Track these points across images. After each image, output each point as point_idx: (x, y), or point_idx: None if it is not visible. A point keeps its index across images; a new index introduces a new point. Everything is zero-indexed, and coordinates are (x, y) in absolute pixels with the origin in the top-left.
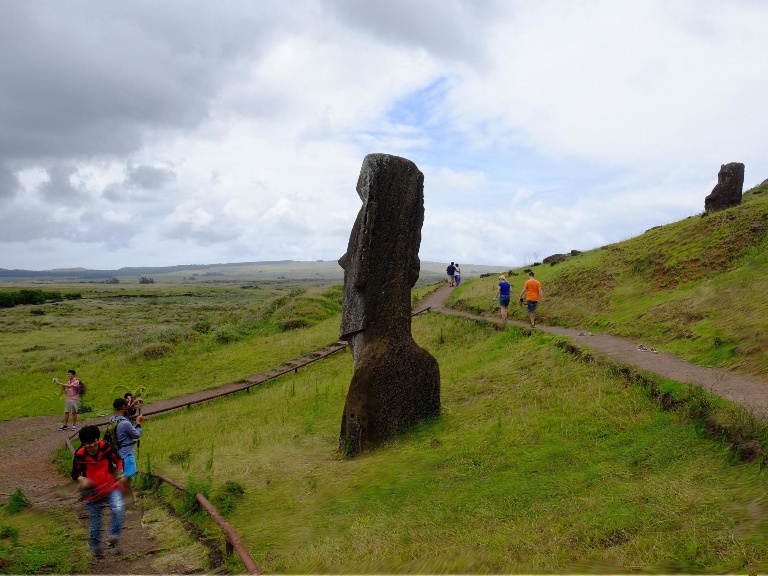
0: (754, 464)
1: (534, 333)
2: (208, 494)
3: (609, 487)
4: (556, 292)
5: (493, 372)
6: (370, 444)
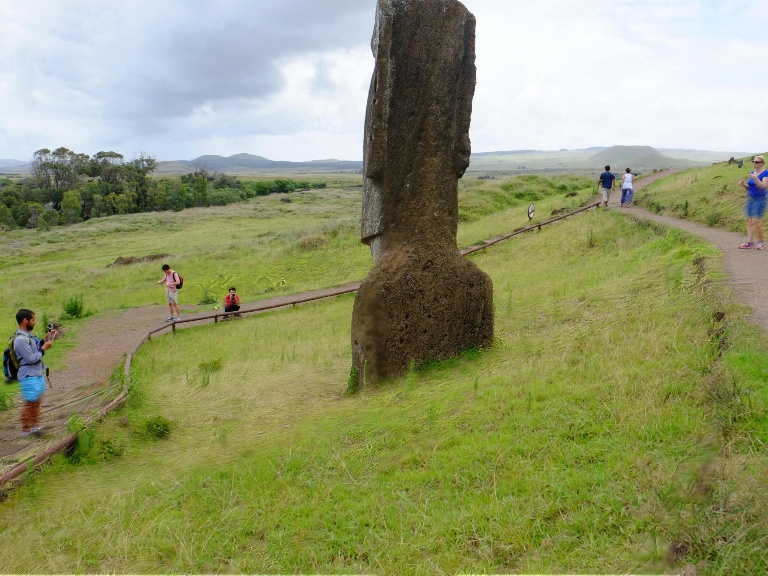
0: None
1: (688, 241)
2: None
3: (416, 575)
4: (759, 185)
5: (599, 293)
6: (378, 379)
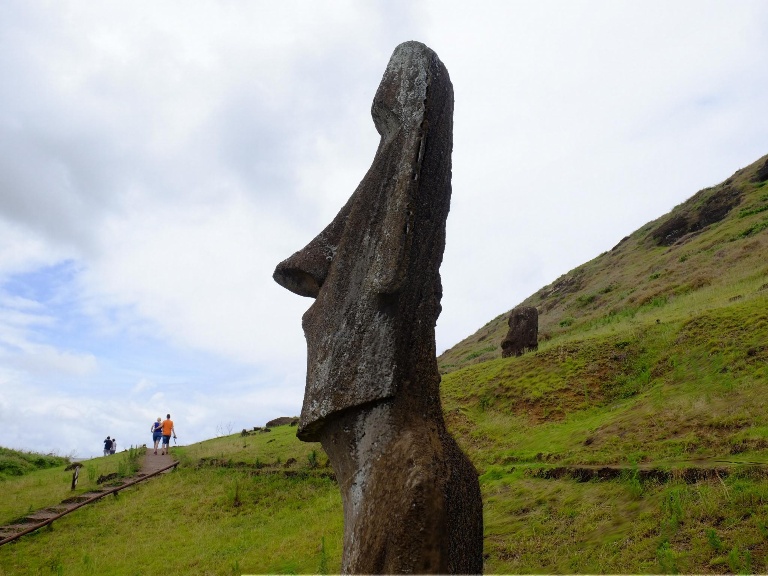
0: None
1: None
2: None
3: None
4: None
5: None
6: None
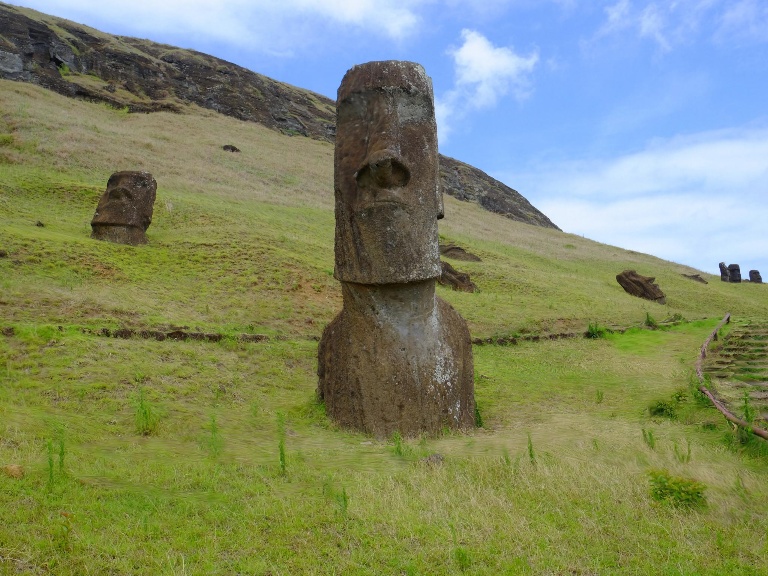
0: (524, 341)
1: None
2: (683, 406)
3: None
4: None
5: (138, 370)
6: None
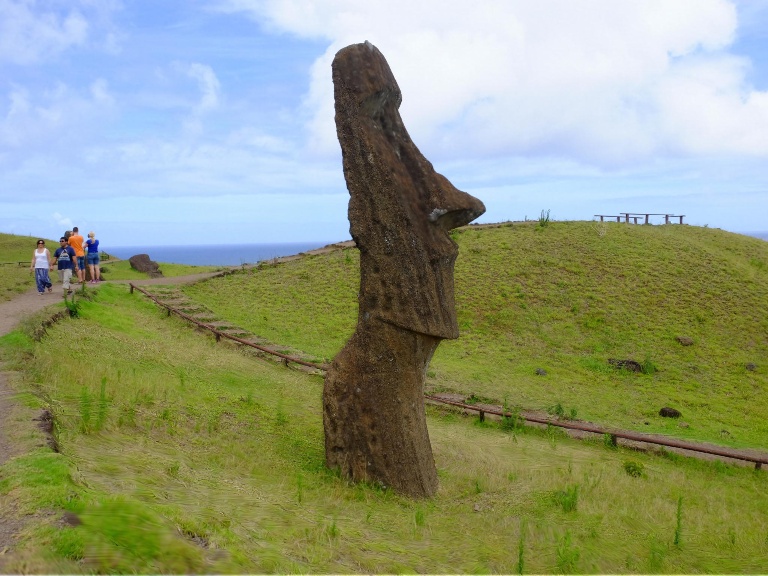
0: None
1: None
2: None
3: None
4: None
5: (303, 524)
6: None
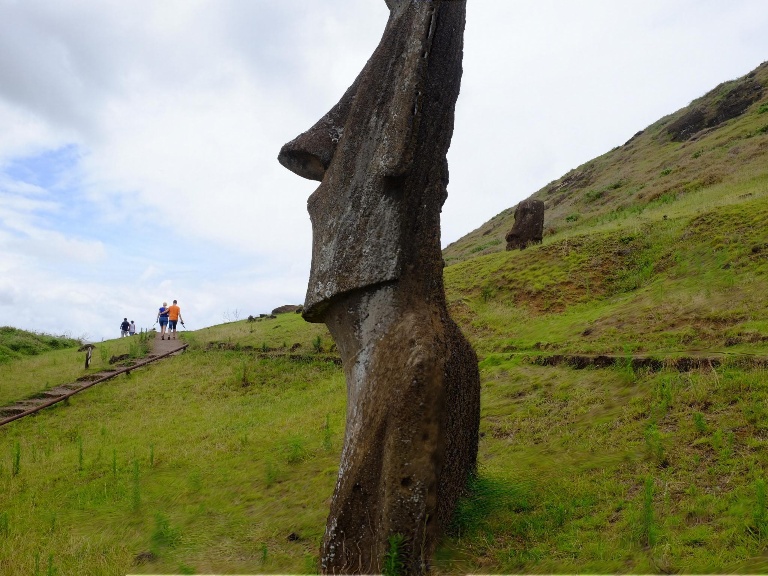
0: None
1: None
2: None
3: None
4: None
5: None
6: (437, 552)
